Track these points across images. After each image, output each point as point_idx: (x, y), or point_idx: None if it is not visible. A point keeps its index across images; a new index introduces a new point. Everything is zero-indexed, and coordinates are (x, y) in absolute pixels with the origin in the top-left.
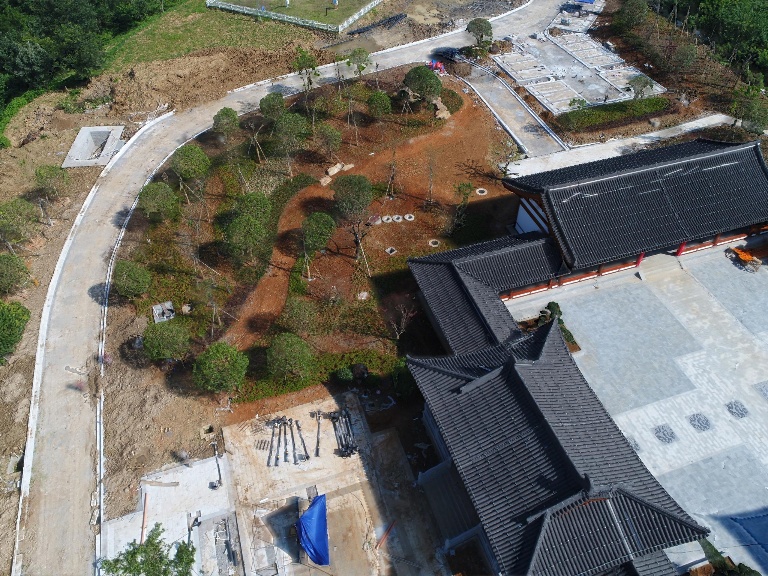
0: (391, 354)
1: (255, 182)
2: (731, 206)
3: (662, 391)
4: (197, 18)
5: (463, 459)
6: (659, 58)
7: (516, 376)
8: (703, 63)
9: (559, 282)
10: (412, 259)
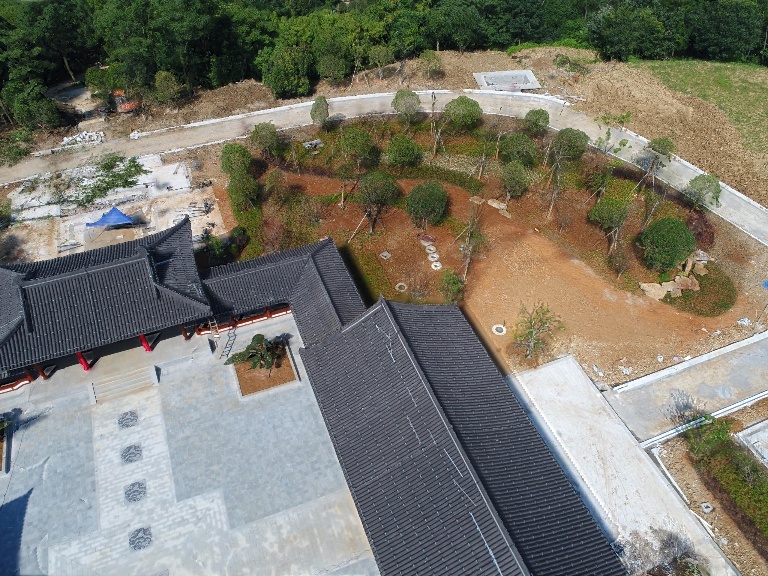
0: None
1: (464, 159)
2: (419, 567)
3: (181, 464)
4: None
5: None
6: None
7: None
8: None
9: None
10: (329, 238)
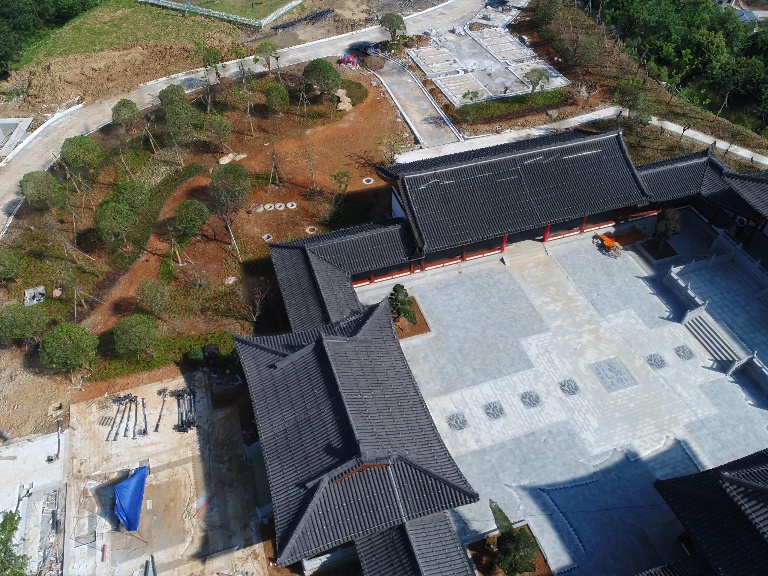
0: (247, 335)
1: (146, 171)
2: (589, 193)
3: (501, 370)
4: (126, 13)
5: (267, 430)
6: (568, 52)
7: (324, 351)
8: (610, 57)
9: (421, 267)
10: (272, 244)
